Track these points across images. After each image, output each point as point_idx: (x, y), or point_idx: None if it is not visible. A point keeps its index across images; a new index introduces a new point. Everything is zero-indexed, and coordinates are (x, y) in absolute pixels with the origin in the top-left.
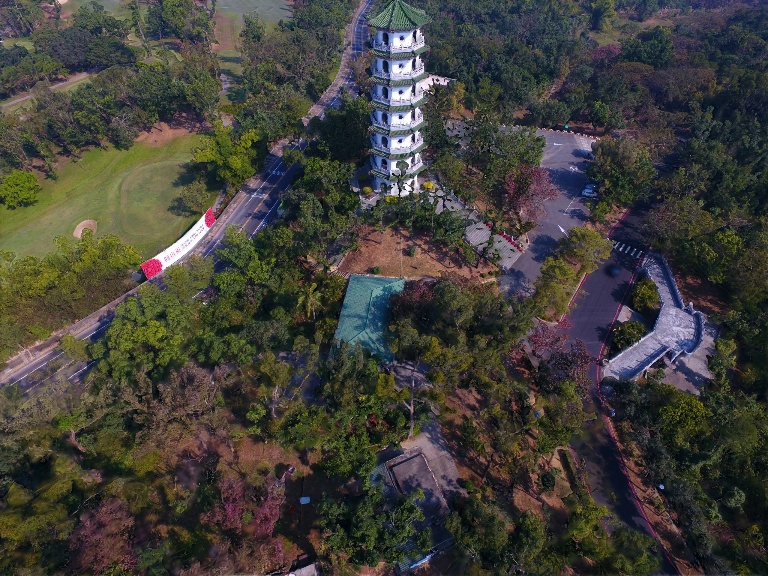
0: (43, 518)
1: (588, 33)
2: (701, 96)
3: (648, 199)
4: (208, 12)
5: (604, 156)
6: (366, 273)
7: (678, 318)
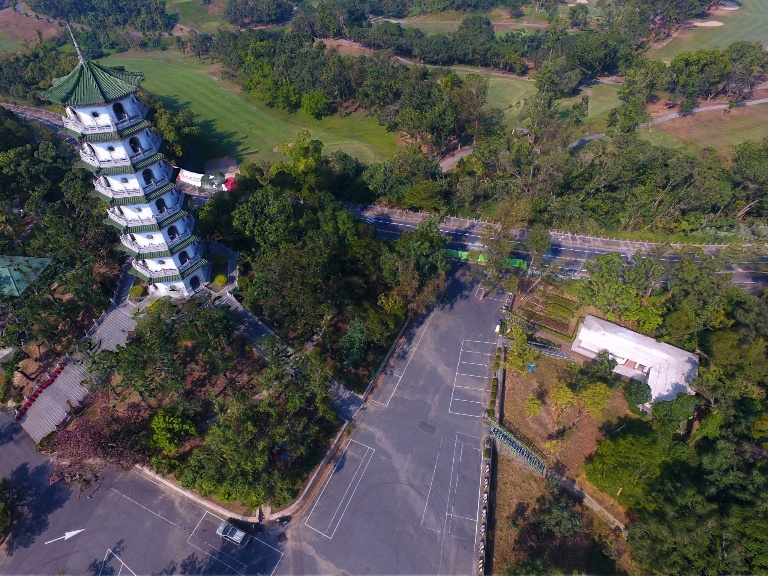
0: None
1: None
2: None
3: None
4: (746, 91)
5: None
6: None
7: None
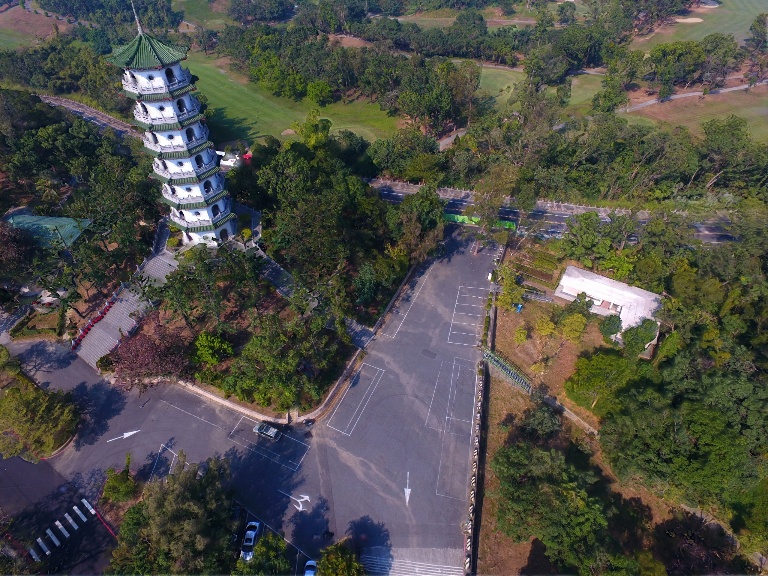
0: None
1: None
2: None
3: None
4: (719, 78)
5: None
6: None
7: None
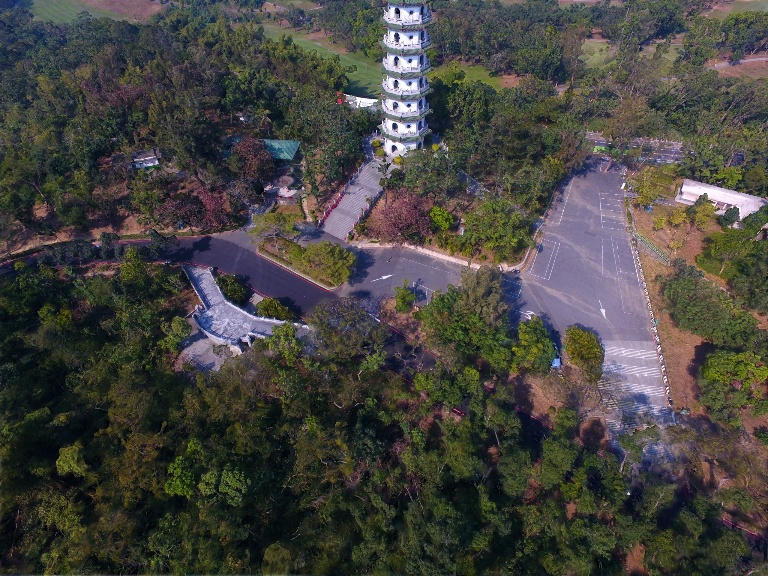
0: (151, 64)
1: None
2: None
3: None
4: None
5: None
6: None
7: (237, 327)
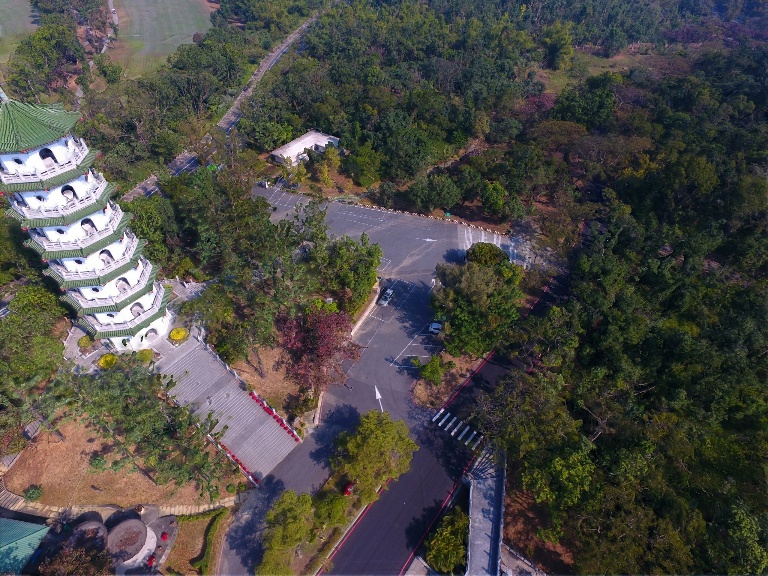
0: None
1: (535, 74)
2: (630, 174)
3: (505, 351)
4: (96, 44)
5: (446, 288)
6: (22, 496)
7: None
